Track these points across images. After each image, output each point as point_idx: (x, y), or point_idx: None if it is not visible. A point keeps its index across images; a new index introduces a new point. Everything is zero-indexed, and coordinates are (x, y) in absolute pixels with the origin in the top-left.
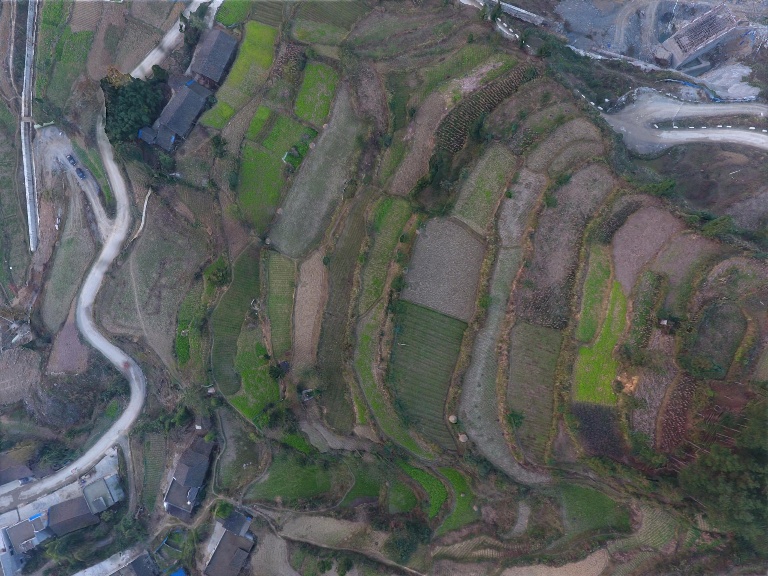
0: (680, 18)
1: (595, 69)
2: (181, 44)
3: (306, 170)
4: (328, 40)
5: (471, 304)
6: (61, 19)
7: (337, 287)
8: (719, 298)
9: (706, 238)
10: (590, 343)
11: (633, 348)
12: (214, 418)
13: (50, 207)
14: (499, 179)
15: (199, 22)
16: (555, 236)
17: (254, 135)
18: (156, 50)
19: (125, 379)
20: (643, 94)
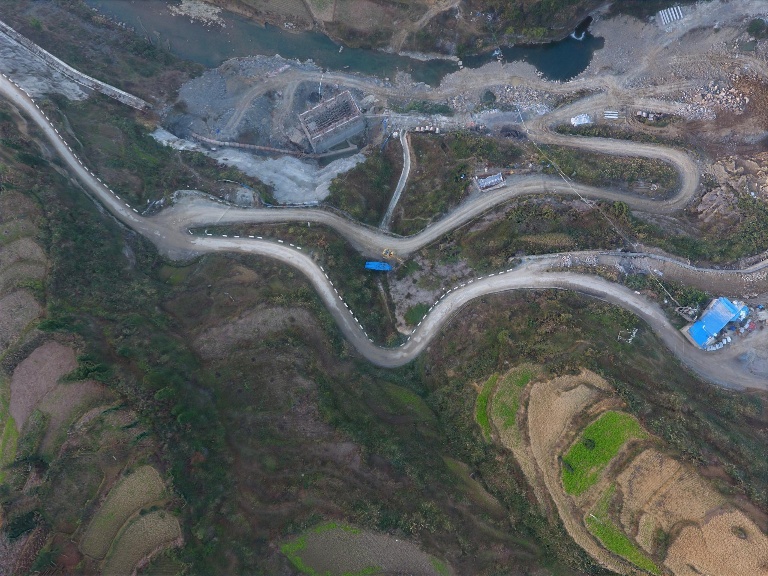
0: (328, 98)
1: (173, 161)
2: None
3: None
4: None
5: None
6: None
7: None
8: (79, 448)
9: (91, 381)
10: None
11: (12, 489)
12: None
13: None
14: None
15: None
16: None
17: None
18: None
19: None
20: (185, 197)
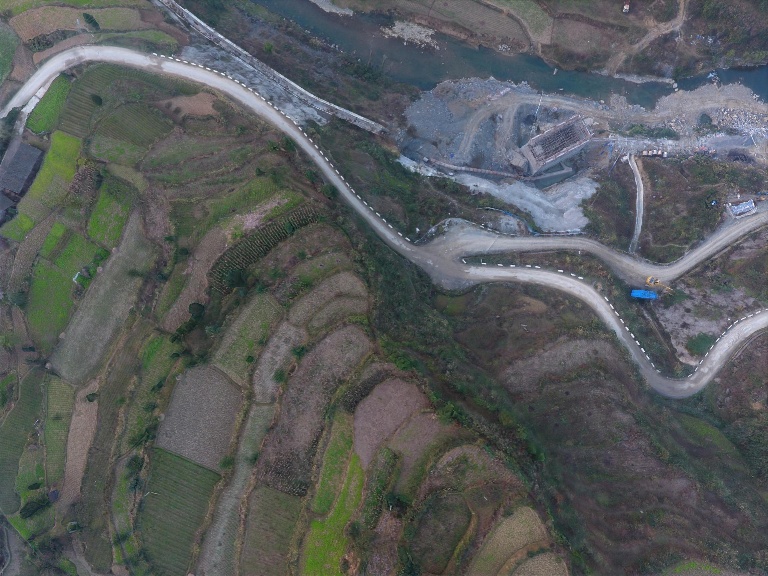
0: (544, 121)
1: (423, 187)
2: None
3: (92, 294)
4: (126, 159)
5: (226, 456)
6: None
7: (106, 422)
8: (445, 488)
9: (445, 419)
10: (324, 516)
11: (362, 527)
12: (0, 531)
13: None
14: (263, 329)
15: (1, 132)
16: (304, 399)
17: (47, 252)
18: None
19: None
20: (455, 225)
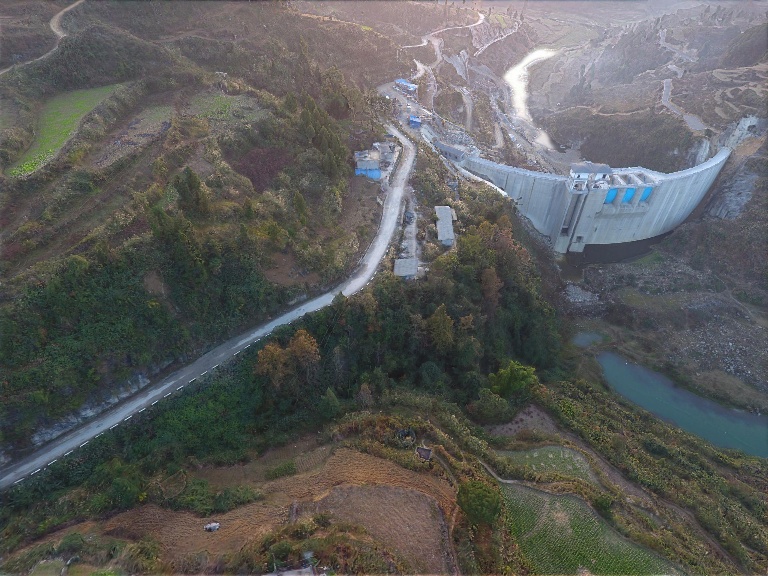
0: None
1: None
2: None
3: None
4: None
5: None
6: None
7: None
8: None
9: None
10: None
11: None
12: None
13: None
14: None
15: (453, 5)
16: None
17: None
18: None
19: None
20: None
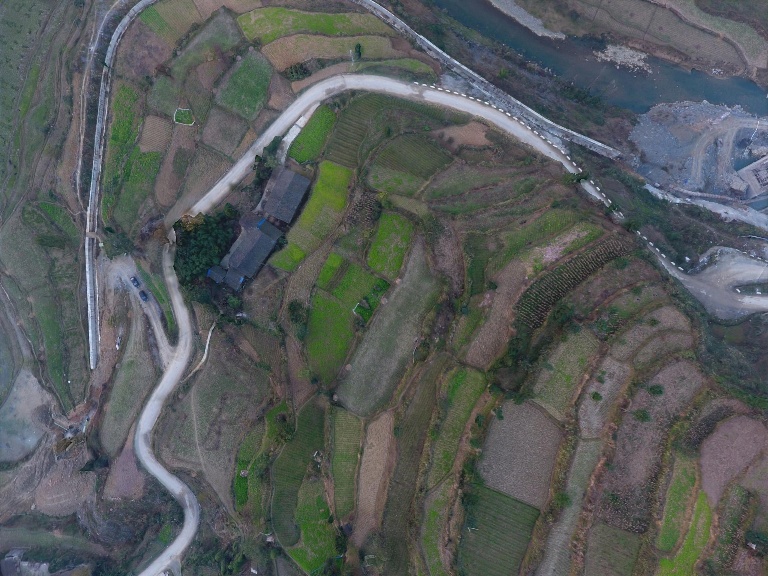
0: (758, 144)
1: (673, 214)
2: (251, 174)
3: (377, 326)
4: (405, 189)
5: (544, 490)
6: (130, 136)
7: (405, 455)
8: None
9: None
10: (670, 553)
11: (716, 565)
12: (270, 562)
13: (111, 326)
14: (580, 363)
15: (274, 162)
16: (638, 435)
17: (325, 283)
18: (226, 178)
19: (179, 506)
20: (726, 255)
